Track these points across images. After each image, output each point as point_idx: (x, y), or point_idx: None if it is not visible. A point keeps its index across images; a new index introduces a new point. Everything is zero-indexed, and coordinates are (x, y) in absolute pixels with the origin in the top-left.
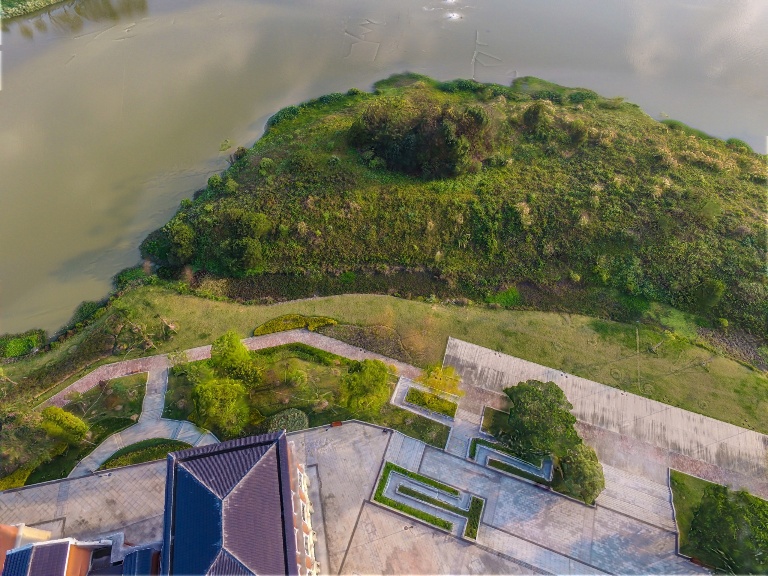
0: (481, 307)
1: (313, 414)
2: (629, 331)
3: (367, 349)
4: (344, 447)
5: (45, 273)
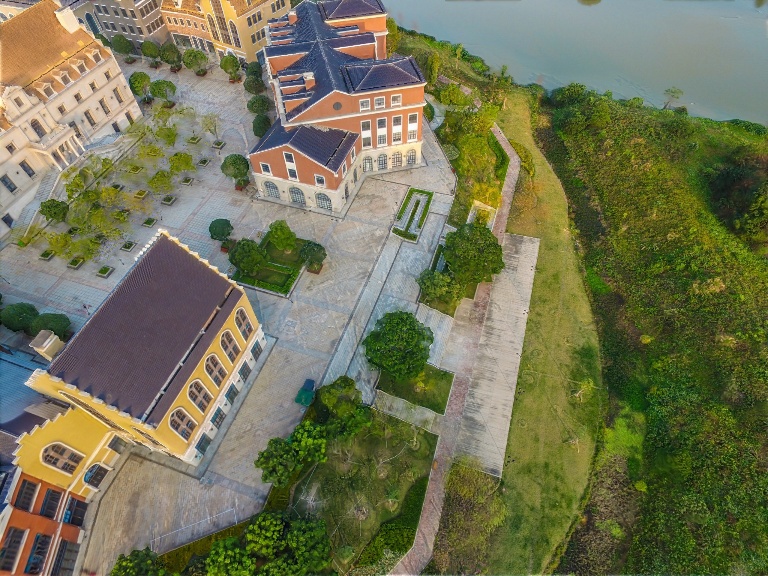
0: (579, 263)
1: (458, 161)
2: (593, 379)
3: (515, 193)
4: (440, 175)
5: (527, 61)
